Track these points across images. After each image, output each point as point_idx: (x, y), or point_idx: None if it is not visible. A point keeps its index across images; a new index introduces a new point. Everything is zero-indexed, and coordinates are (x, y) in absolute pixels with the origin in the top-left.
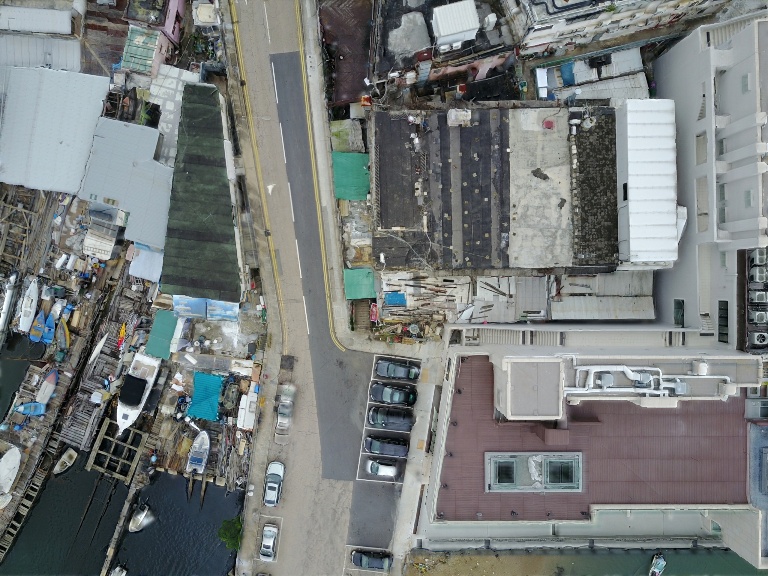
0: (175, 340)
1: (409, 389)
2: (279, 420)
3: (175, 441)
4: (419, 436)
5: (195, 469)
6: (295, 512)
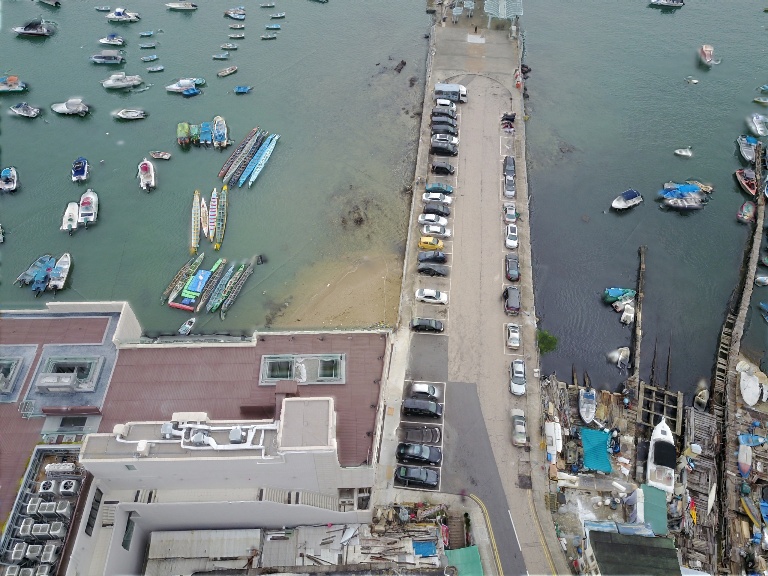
0: (641, 500)
1: (405, 458)
2: (524, 427)
3: (611, 416)
4: (392, 418)
5: (588, 392)
6: (495, 358)
